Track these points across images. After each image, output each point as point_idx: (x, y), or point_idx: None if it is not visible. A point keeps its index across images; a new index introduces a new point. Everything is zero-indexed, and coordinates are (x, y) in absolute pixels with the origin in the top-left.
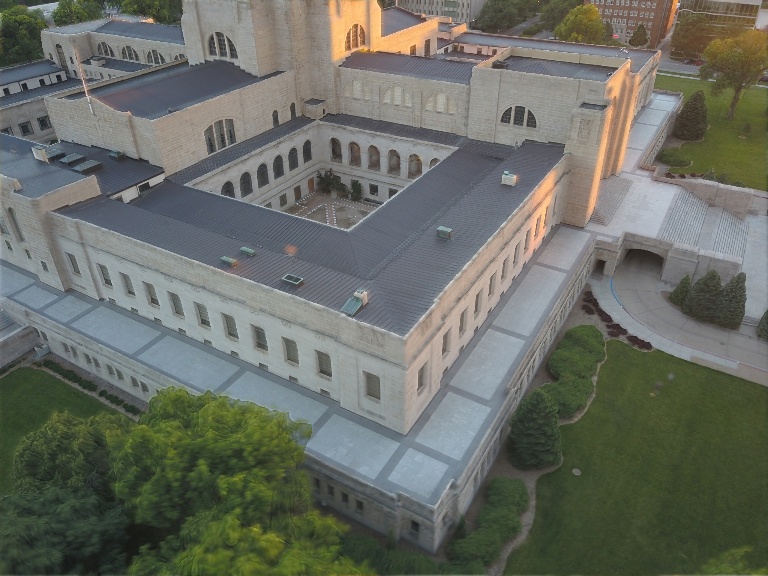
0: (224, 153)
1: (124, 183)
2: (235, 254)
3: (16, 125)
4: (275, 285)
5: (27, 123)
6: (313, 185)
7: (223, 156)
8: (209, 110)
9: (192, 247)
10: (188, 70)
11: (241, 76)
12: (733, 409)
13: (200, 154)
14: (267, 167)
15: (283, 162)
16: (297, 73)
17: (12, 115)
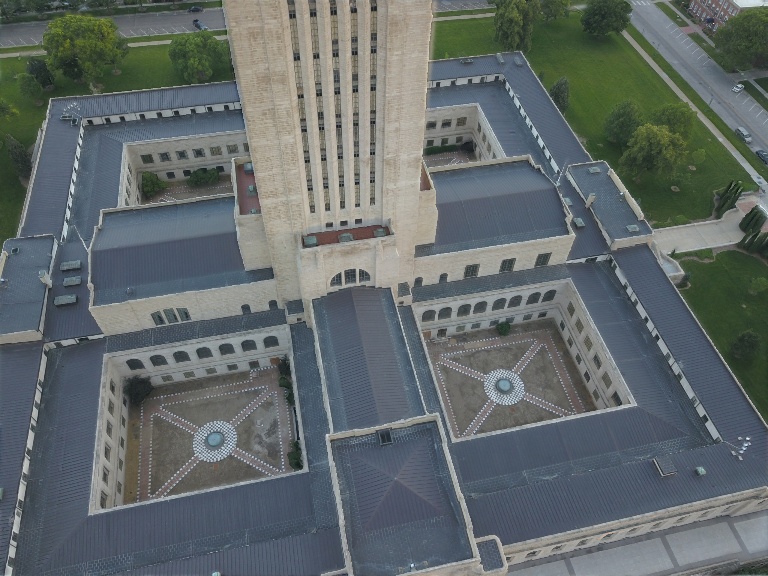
0: (173, 327)
1: (68, 333)
2: None
3: (173, 152)
4: None
5: (184, 151)
6: (279, 361)
7: (168, 331)
8: (155, 303)
9: None
10: (198, 236)
11: (235, 261)
12: None
13: (146, 325)
14: (210, 349)
15: (234, 347)
16: (279, 283)
17: (171, 145)
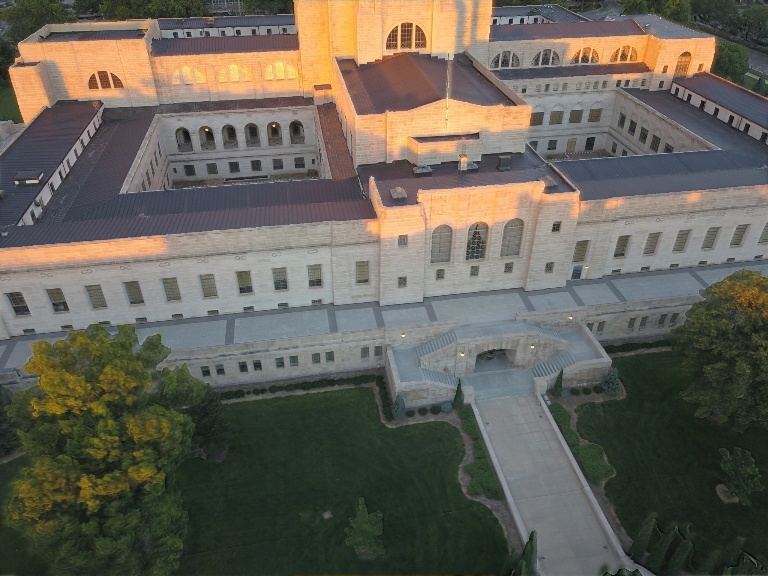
0: None
1: None
2: (215, 23)
3: None
4: (186, 21)
5: None
6: None
7: None
8: None
9: (235, 21)
10: None
11: None
12: (6, 116)
13: None
14: None
15: None
16: None
17: None
